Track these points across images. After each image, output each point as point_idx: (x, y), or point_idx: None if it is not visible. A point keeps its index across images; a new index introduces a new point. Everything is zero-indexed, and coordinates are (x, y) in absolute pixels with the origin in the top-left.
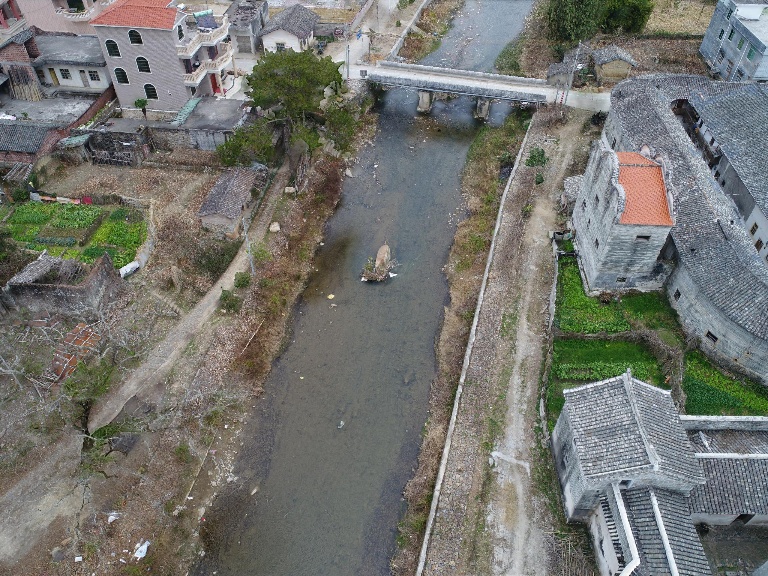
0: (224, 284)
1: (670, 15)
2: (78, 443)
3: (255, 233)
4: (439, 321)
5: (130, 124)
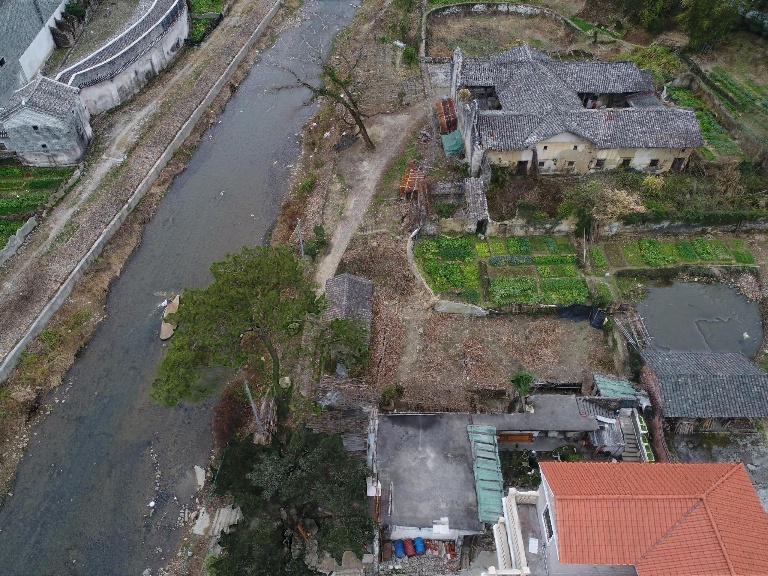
0: (332, 262)
1: None
2: (384, 157)
3: (317, 320)
4: (129, 263)
5: (553, 414)
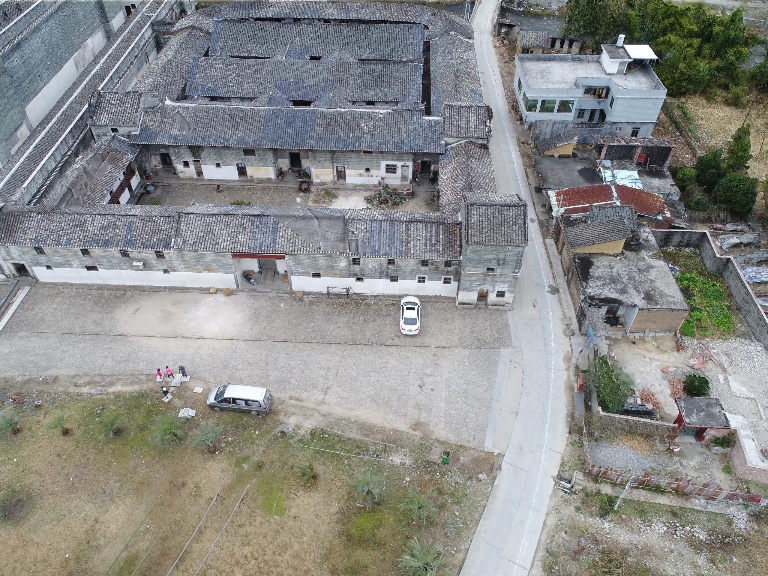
0: None
1: (759, 126)
2: None
3: None
4: None
5: None
